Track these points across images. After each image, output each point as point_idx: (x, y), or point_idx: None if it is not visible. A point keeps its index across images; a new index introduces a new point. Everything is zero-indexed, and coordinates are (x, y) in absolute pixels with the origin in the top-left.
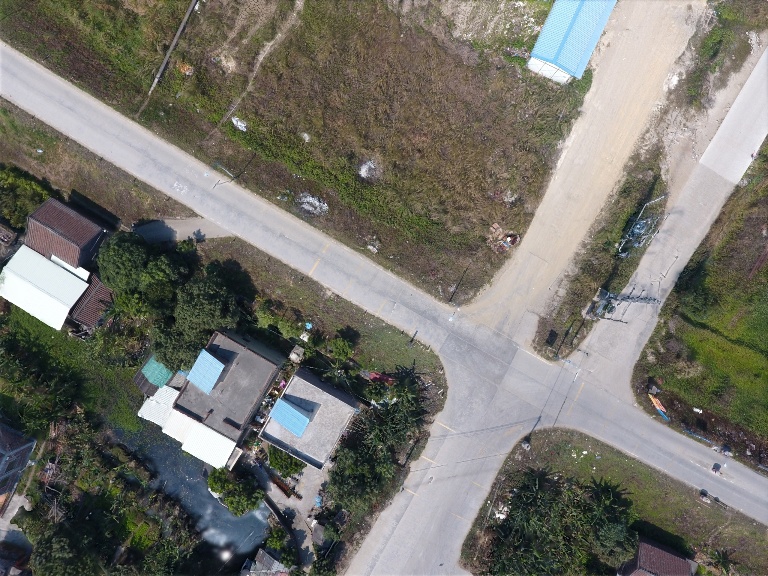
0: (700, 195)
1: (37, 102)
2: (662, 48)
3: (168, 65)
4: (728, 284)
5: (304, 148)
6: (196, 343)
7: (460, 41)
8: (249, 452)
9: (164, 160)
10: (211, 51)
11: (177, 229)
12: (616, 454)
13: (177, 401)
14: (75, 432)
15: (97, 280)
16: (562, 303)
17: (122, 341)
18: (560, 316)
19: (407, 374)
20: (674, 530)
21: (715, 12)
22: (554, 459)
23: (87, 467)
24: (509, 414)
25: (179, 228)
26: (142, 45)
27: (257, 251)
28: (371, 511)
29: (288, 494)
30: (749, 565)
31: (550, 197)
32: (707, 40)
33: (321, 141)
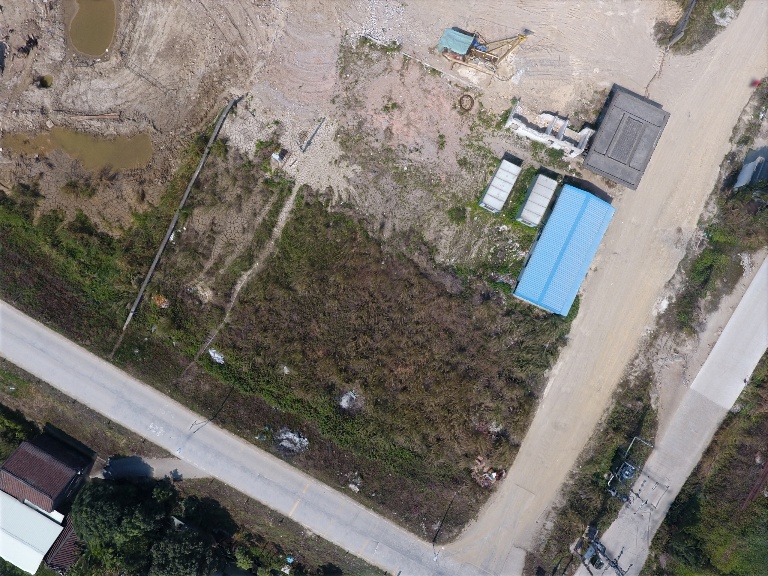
0: (691, 422)
1: (8, 344)
2: (651, 272)
3: (143, 297)
4: (721, 515)
5: (283, 381)
6: None
7: (443, 267)
8: None
9: (139, 401)
10: (187, 282)
11: (154, 466)
12: None
13: None
14: None
15: (72, 523)
16: (550, 537)
17: (99, 574)
18: (548, 552)
19: None
20: None
21: (706, 234)
22: None
23: None
24: None
25: (156, 465)
26: (116, 279)
27: (235, 492)
28: None
29: None
30: None
31: (537, 427)
32: (697, 264)
33: (301, 373)
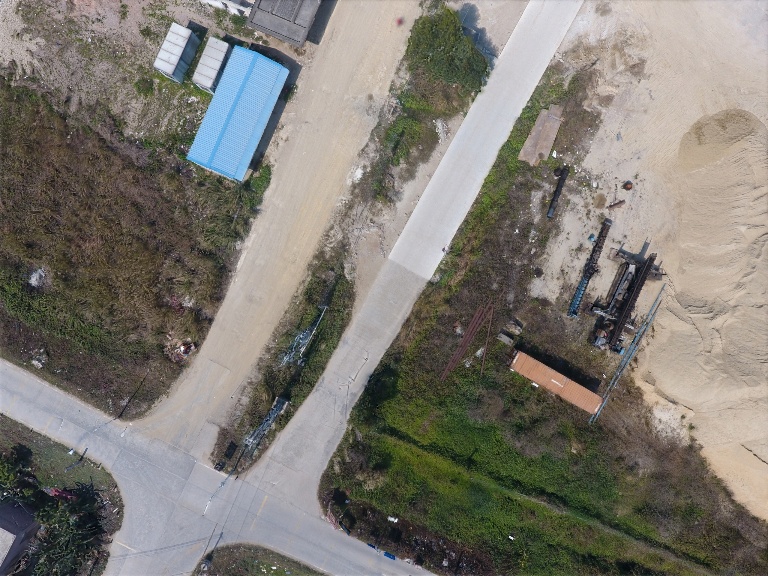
0: (390, 293)
1: None
2: (343, 141)
3: None
4: (419, 386)
5: None
6: None
7: (130, 140)
8: None
9: None
10: None
11: None
12: (303, 570)
13: None
14: None
15: None
16: (244, 412)
17: None
18: (240, 427)
19: (87, 490)
20: None
21: (398, 101)
22: (245, 574)
23: None
24: (189, 531)
25: None
26: None
27: None
28: None
29: None
30: None
31: (230, 301)
32: (390, 131)
33: None
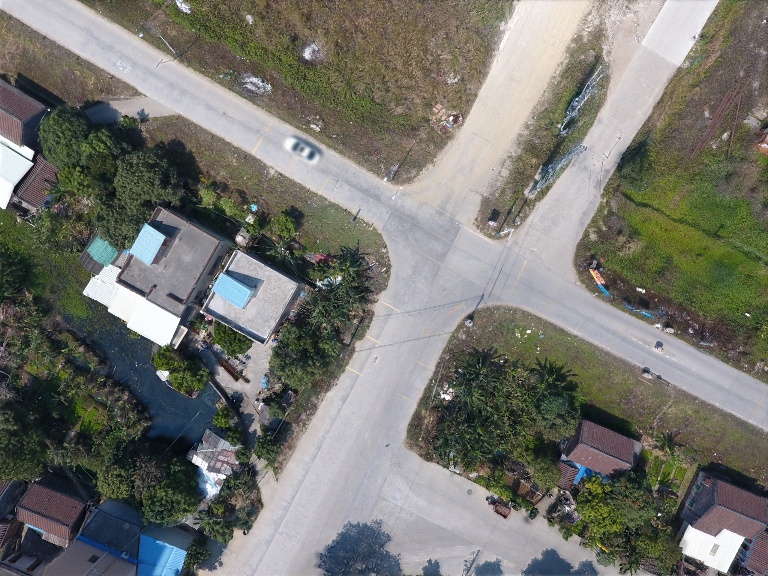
0: (643, 77)
1: None
2: None
3: None
4: (670, 164)
5: (248, 29)
6: (139, 218)
7: None
8: (197, 336)
9: (107, 39)
10: None
11: (122, 110)
12: (559, 332)
13: (121, 276)
14: (23, 315)
15: (42, 159)
16: (505, 183)
17: (69, 225)
18: (503, 195)
19: (352, 255)
20: (619, 413)
21: None
22: (498, 339)
23: (35, 349)
24: (452, 292)
25: (124, 109)
26: None
27: (200, 129)
28: (316, 391)
29: (235, 377)
30: (694, 447)
31: (493, 78)
32: None
33: (265, 23)
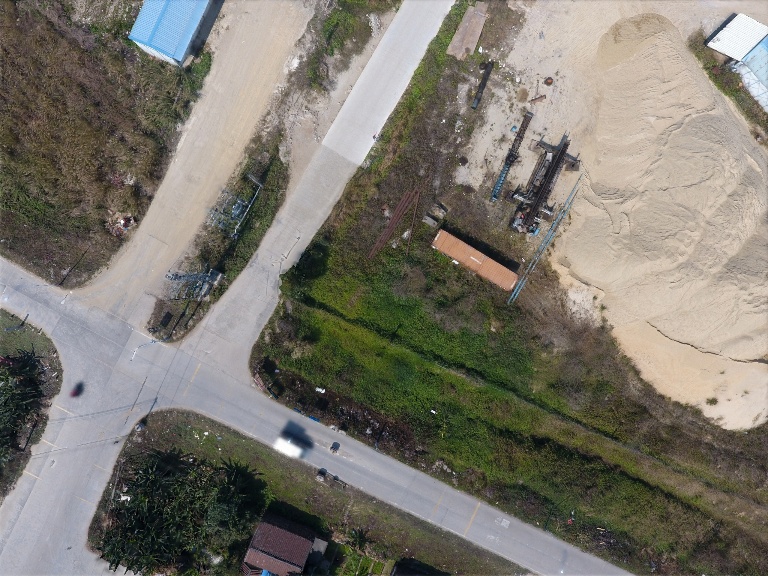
0: (323, 176)
1: None
2: (281, 31)
3: None
4: (348, 264)
5: None
6: None
7: (78, 25)
8: None
9: None
10: None
11: None
12: (233, 434)
13: None
14: None
15: None
16: None
17: None
18: None
19: (29, 358)
20: (311, 510)
21: None
22: (179, 441)
23: None
24: (126, 396)
25: None
26: None
27: None
28: None
29: None
30: (385, 543)
31: (170, 180)
32: (325, 23)
33: None
